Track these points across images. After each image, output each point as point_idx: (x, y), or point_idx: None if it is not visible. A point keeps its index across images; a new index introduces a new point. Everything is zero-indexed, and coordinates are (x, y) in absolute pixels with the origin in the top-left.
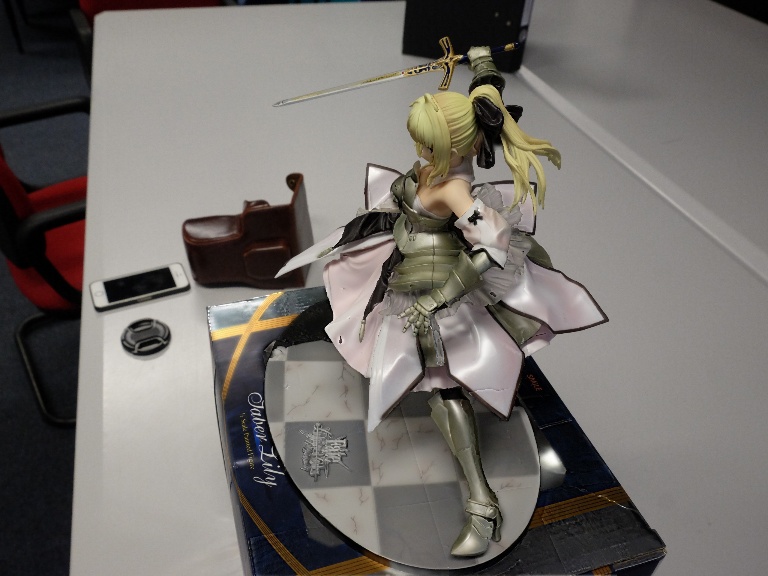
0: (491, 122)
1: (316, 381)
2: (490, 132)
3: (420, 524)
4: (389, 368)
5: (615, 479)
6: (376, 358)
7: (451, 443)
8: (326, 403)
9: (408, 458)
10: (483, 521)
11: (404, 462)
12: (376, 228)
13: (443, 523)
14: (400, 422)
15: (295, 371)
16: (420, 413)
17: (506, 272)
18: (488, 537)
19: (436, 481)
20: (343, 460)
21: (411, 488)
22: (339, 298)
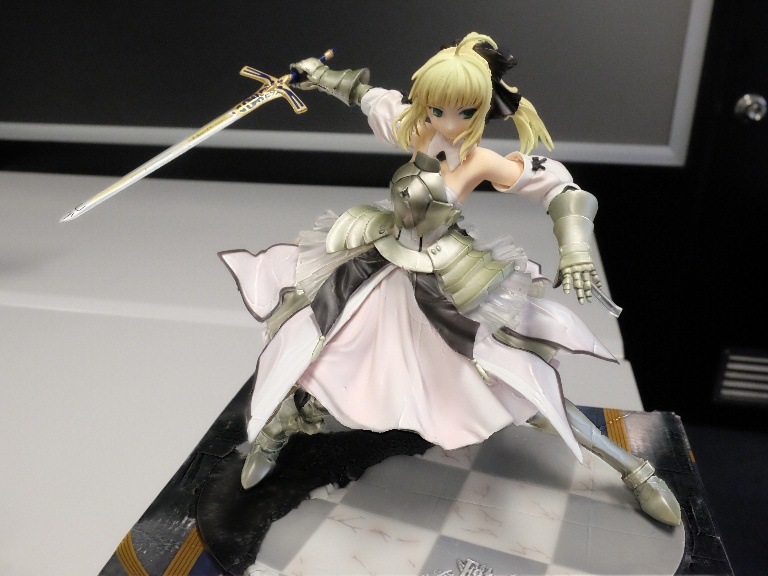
0: (510, 61)
1: (343, 555)
2: (498, 78)
3: (619, 543)
4: (537, 385)
5: (594, 408)
6: (519, 386)
7: (583, 437)
8: (390, 559)
9: (519, 519)
10: (655, 479)
11: (524, 524)
12: (354, 282)
13: (622, 525)
14: (461, 505)
15: (309, 569)
16: (455, 486)
17: (506, 244)
18: (667, 488)
19: (563, 509)
20: (497, 575)
21: (565, 532)
22: (348, 403)
